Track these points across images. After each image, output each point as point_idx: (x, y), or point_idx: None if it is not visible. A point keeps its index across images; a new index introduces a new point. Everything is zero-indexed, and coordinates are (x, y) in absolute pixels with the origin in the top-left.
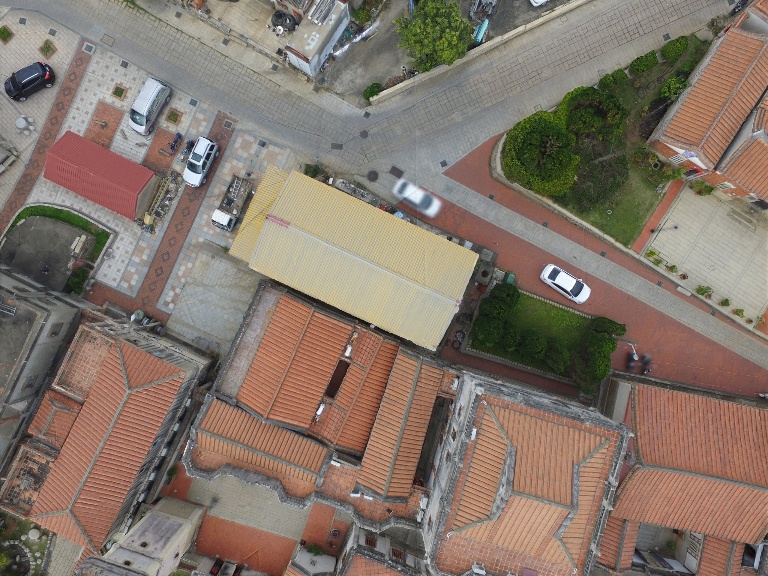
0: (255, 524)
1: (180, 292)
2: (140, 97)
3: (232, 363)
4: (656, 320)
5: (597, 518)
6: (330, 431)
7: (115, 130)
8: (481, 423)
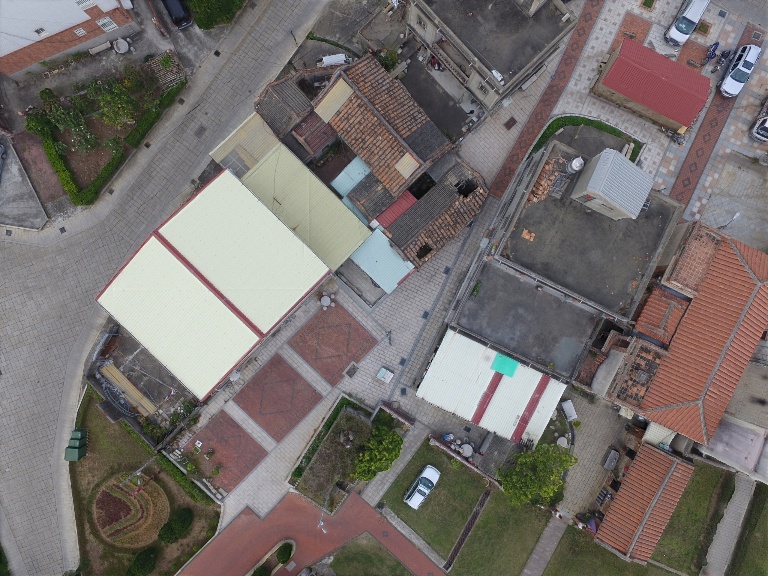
0: None
1: (706, 203)
2: (695, 4)
3: None
4: None
5: None
6: None
7: (643, 41)
8: None
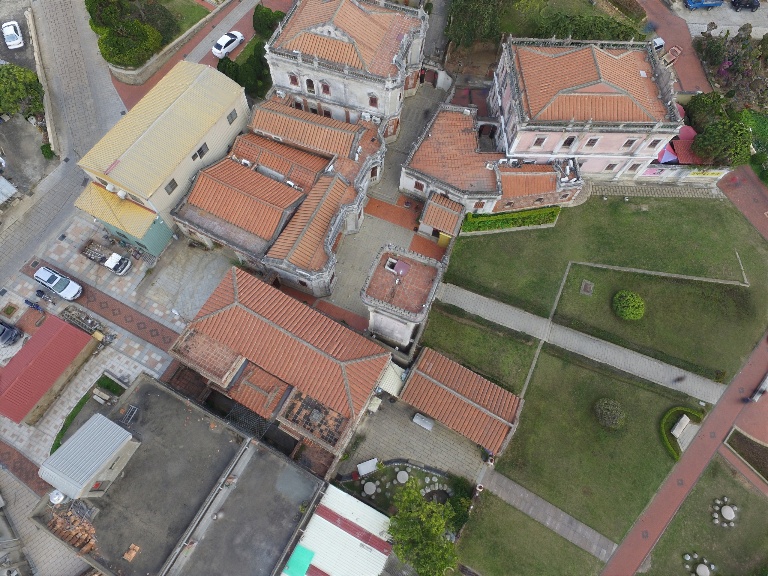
0: None
1: None
2: None
3: None
4: (264, 4)
5: (365, 3)
6: (308, 178)
7: (1, 368)
8: (292, 51)
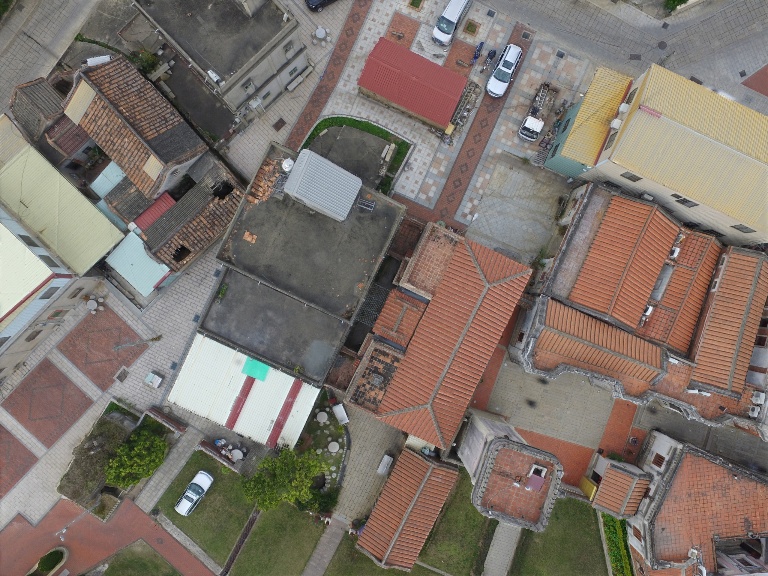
0: (553, 434)
1: (478, 204)
2: (452, 4)
3: (561, 265)
4: None
5: None
6: (658, 331)
7: (412, 41)
8: None
